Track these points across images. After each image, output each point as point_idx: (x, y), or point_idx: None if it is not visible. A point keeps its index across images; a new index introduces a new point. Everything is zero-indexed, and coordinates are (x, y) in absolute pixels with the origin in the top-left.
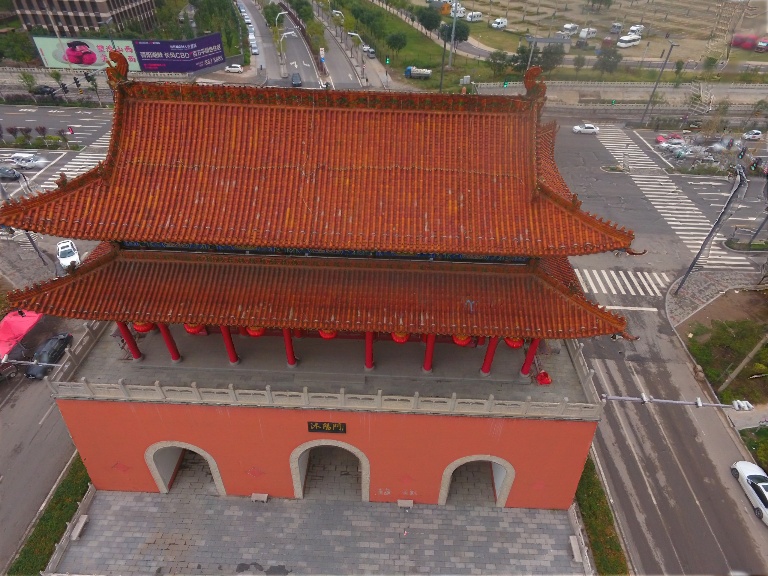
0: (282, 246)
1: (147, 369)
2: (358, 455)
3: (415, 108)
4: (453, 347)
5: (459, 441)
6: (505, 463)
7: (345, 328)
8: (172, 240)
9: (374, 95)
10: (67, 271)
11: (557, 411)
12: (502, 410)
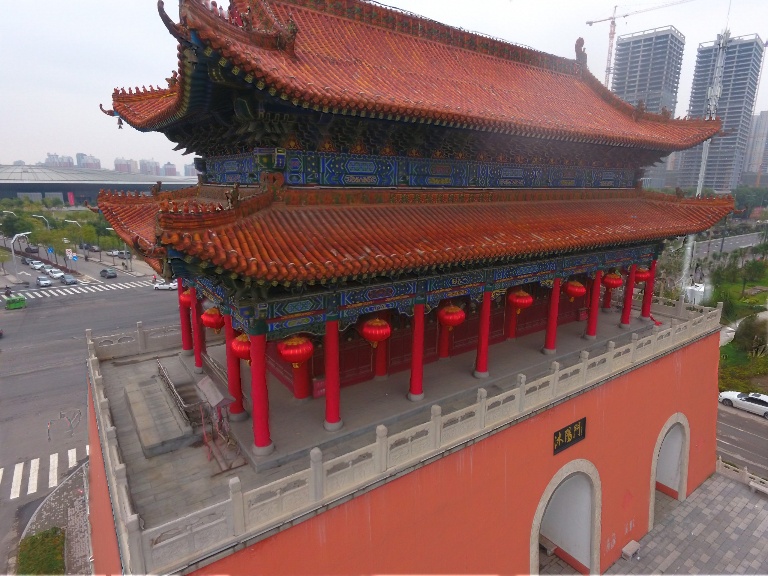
0: (538, 130)
1: (291, 462)
2: (593, 478)
3: (519, 60)
4: (574, 324)
5: (659, 402)
6: (684, 420)
7: (593, 242)
8: (436, 114)
9: (493, 42)
10: (231, 198)
11: (702, 327)
12: (678, 339)
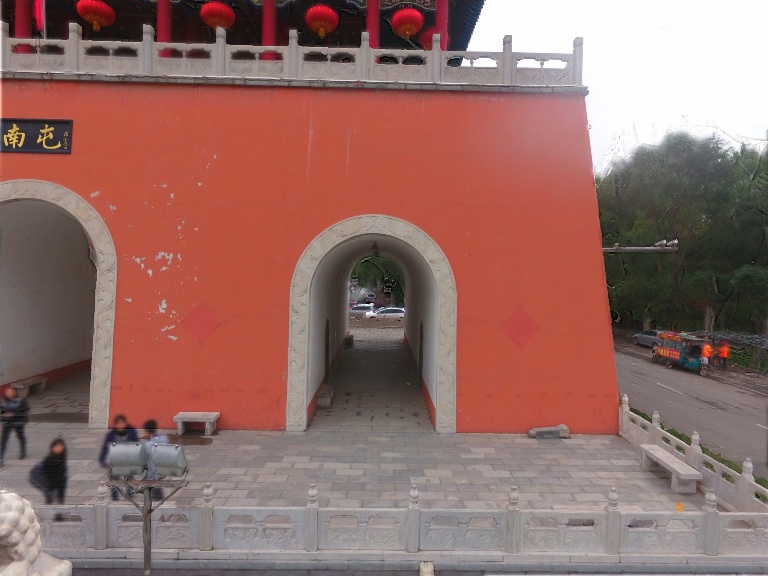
0: None
1: None
2: None
3: None
4: None
5: None
6: None
7: None
8: None
9: None
10: None
11: None
12: None
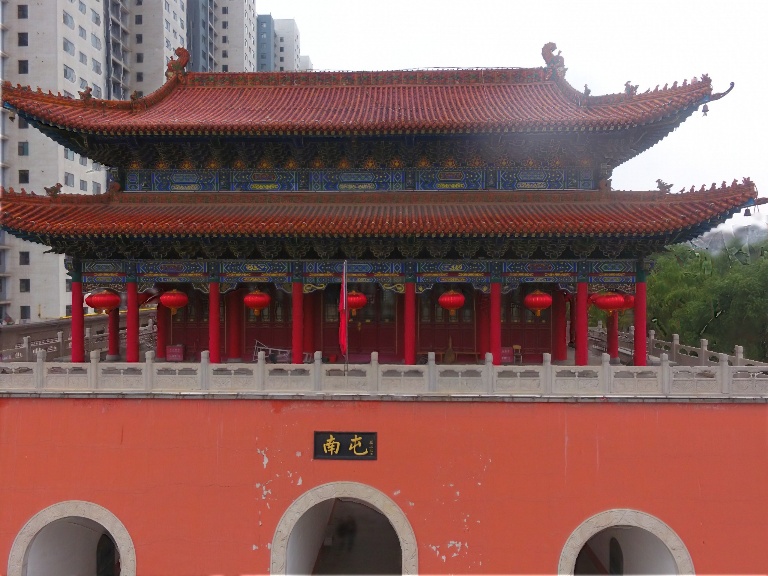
0: None
1: None
2: None
3: (283, 86)
4: None
5: None
6: None
7: None
8: None
9: (320, 75)
10: None
11: None
12: None
